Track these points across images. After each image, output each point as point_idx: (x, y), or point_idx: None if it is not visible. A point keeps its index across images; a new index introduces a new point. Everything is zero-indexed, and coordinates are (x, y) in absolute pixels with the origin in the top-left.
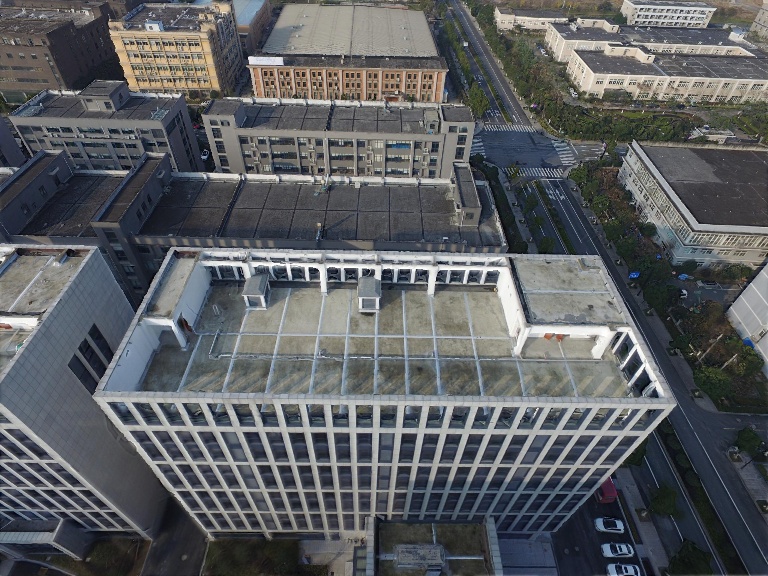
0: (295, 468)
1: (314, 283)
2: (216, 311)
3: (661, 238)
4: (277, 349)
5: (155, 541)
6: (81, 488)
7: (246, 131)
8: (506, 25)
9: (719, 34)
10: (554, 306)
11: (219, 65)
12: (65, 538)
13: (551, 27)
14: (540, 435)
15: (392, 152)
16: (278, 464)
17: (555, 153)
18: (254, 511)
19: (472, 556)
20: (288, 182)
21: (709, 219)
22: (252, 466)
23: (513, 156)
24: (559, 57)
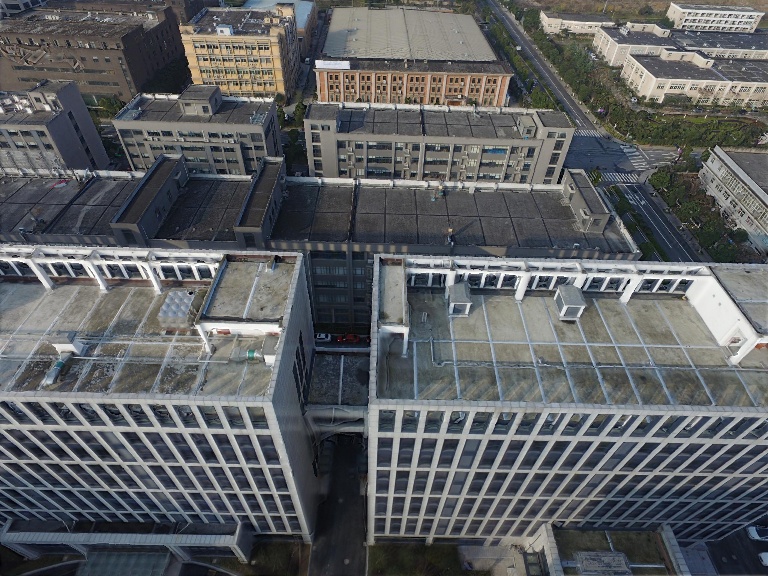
0: (512, 475)
1: (504, 290)
2: (424, 318)
3: (754, 244)
4: (495, 357)
5: (314, 545)
6: (283, 492)
7: (345, 136)
8: (553, 29)
9: None
10: None
11: (285, 69)
12: (243, 541)
13: (601, 31)
14: None
15: (487, 157)
16: (498, 471)
17: (626, 158)
18: (436, 517)
19: (653, 564)
20: (401, 187)
21: None
22: (470, 473)
23: (591, 161)
24: (611, 61)
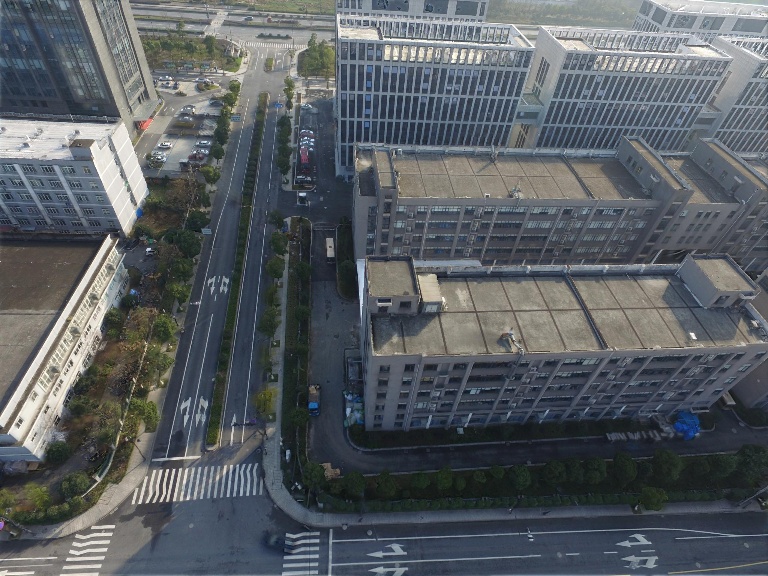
0: None
1: None
2: None
3: None
4: None
5: None
6: None
7: (665, 267)
8: None
9: None
10: None
11: None
12: None
13: None
14: None
15: None
16: None
17: None
18: None
19: None
20: None
21: (76, 253)
22: None
23: None
24: None
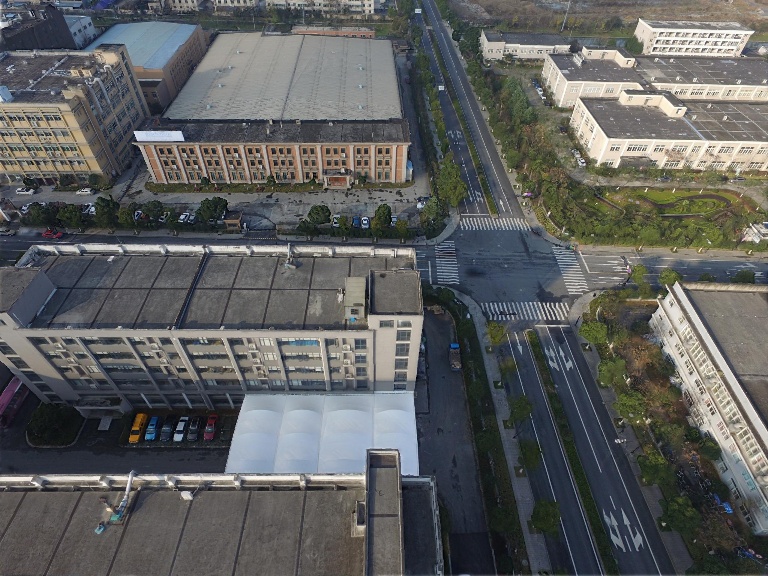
0: None
1: None
2: None
3: (730, 474)
4: None
5: None
6: None
7: (36, 332)
8: (494, 54)
9: (760, 66)
10: None
11: (99, 140)
12: None
13: (550, 60)
14: None
15: (291, 350)
16: None
17: (557, 271)
18: None
19: None
20: (60, 485)
21: None
22: None
23: None
24: (560, 101)
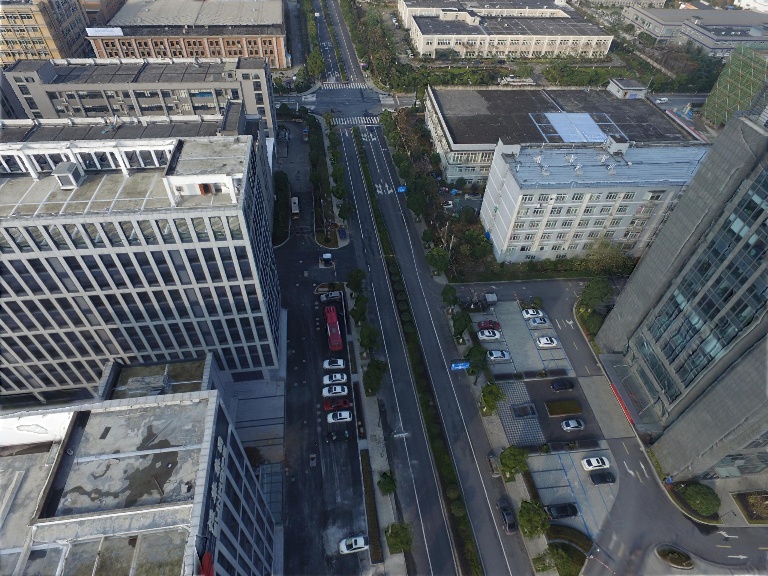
0: (5, 305)
1: None
2: None
3: (442, 163)
4: None
5: None
6: None
7: (52, 86)
8: None
9: None
10: (196, 166)
11: (59, 38)
12: None
13: None
14: (172, 251)
15: (197, 101)
16: None
17: (379, 104)
18: (6, 365)
19: (193, 381)
20: (81, 125)
21: (468, 141)
22: None
23: None
24: (406, 24)
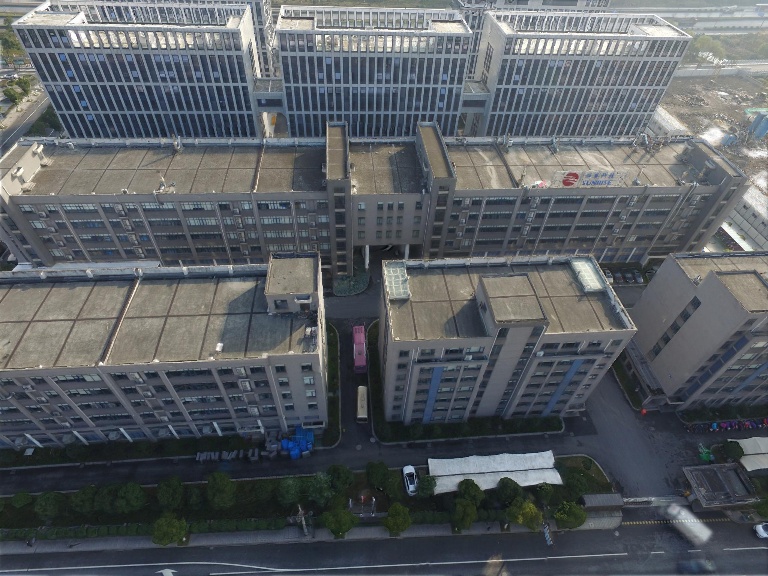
0: None
1: None
2: None
3: None
4: None
5: None
6: None
7: (260, 267)
8: None
9: None
10: (61, 17)
11: None
12: None
13: None
14: None
15: None
16: None
17: None
18: None
19: None
20: None
21: None
22: None
23: None
24: None
